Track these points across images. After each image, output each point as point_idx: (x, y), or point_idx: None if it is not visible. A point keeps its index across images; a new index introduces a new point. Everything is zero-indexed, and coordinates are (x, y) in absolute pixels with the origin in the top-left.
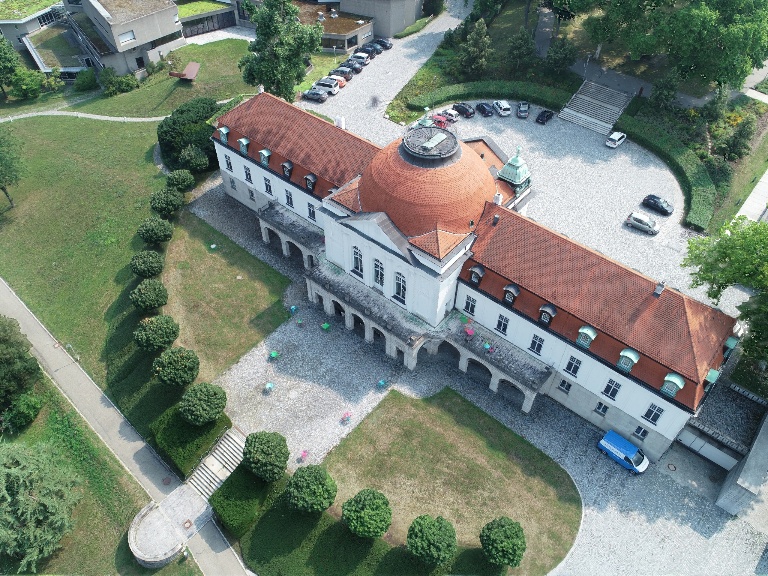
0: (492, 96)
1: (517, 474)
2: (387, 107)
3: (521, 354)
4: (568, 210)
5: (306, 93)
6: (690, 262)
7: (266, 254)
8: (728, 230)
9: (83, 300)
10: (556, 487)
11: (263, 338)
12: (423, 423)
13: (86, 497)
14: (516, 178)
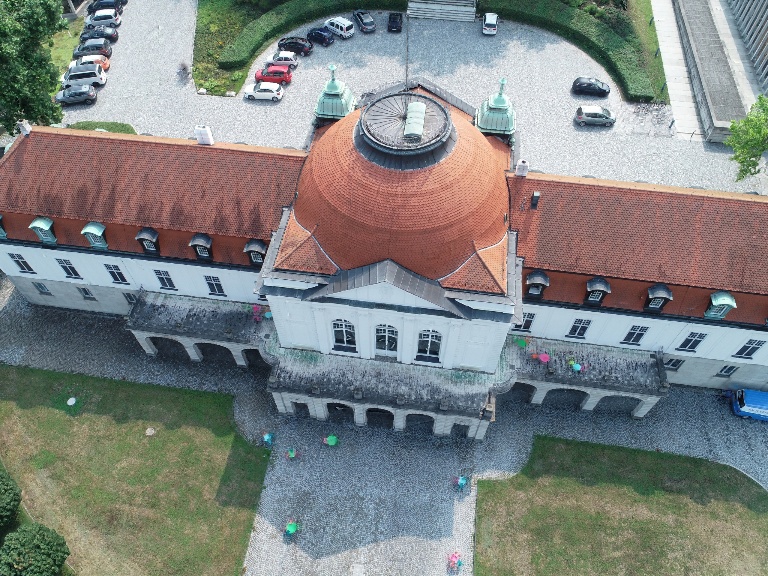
0: (315, 16)
1: (689, 504)
2: (193, 77)
3: (613, 353)
4: None
5: (61, 98)
6: (747, 152)
7: (165, 372)
8: (670, 89)
9: None
10: (736, 493)
11: (255, 510)
12: (547, 506)
13: None
14: (509, 125)
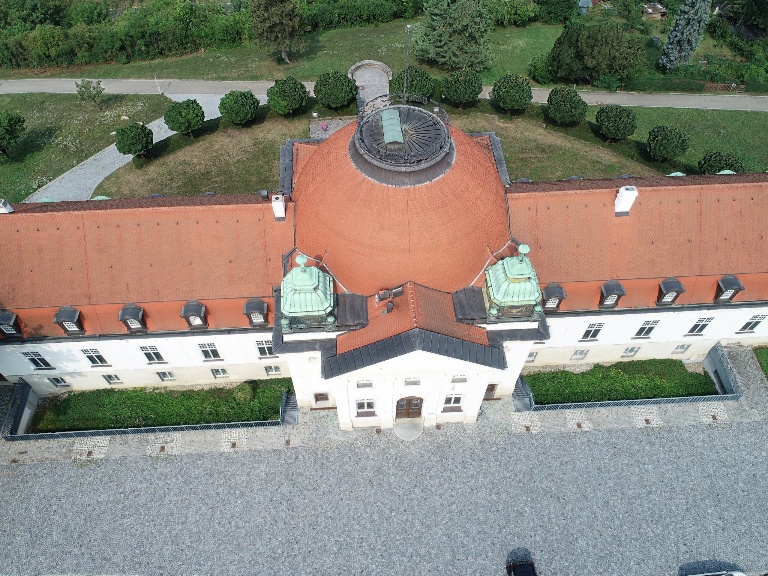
0: None
1: None
2: None
3: None
4: (279, 574)
5: None
6: None
7: None
8: None
9: (644, 127)
10: None
11: None
12: None
13: (441, 77)
14: None
